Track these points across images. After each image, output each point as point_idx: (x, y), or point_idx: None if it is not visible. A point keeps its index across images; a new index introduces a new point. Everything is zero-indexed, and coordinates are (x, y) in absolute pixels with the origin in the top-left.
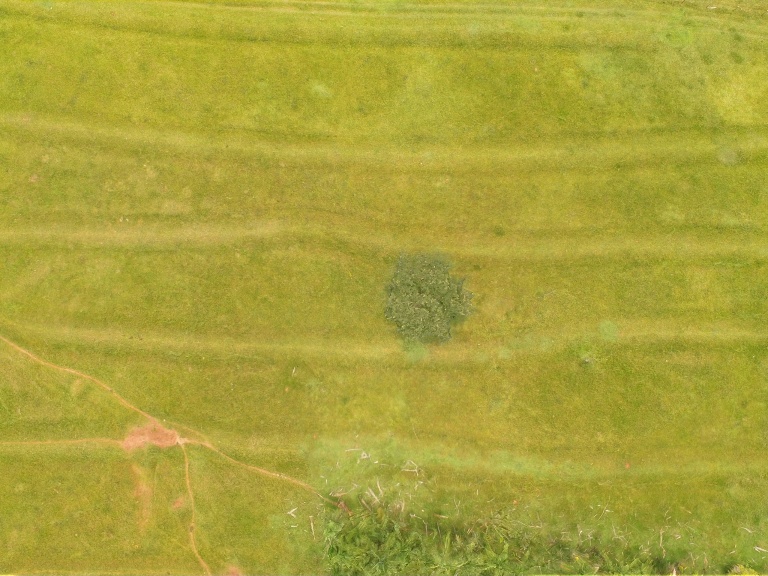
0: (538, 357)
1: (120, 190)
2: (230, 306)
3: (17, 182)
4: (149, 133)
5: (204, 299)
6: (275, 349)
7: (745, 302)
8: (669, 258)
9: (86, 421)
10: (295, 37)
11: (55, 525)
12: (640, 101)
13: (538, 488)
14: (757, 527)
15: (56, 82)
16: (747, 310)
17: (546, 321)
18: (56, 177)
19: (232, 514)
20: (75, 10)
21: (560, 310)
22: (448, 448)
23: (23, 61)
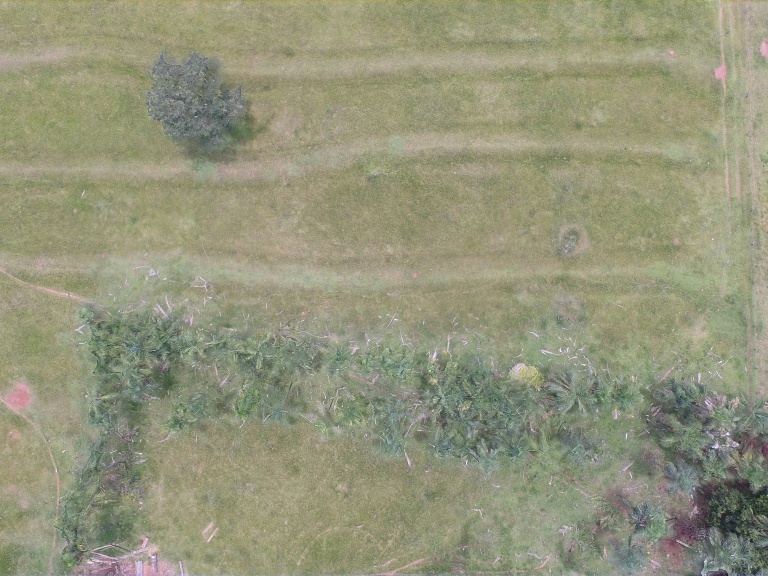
0: (328, 173)
1: None
2: (18, 131)
3: None
4: None
5: None
6: (63, 172)
7: (534, 114)
8: (459, 74)
9: None
10: None
11: None
12: None
13: (327, 300)
14: (544, 331)
15: None
16: (536, 122)
17: (335, 138)
18: None
19: (19, 333)
20: None
21: (349, 127)
22: (237, 264)
23: None
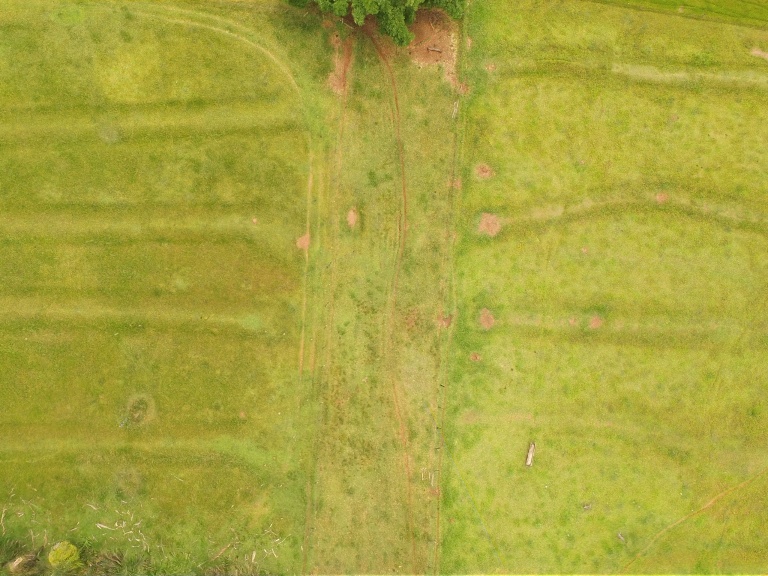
0: None
1: None
2: None
3: None
4: None
5: None
6: None
7: (113, 280)
8: (41, 236)
9: None
10: None
11: None
12: (26, 80)
13: None
14: (102, 504)
15: None
16: (114, 288)
17: None
18: None
19: None
20: None
21: None
22: None
23: None
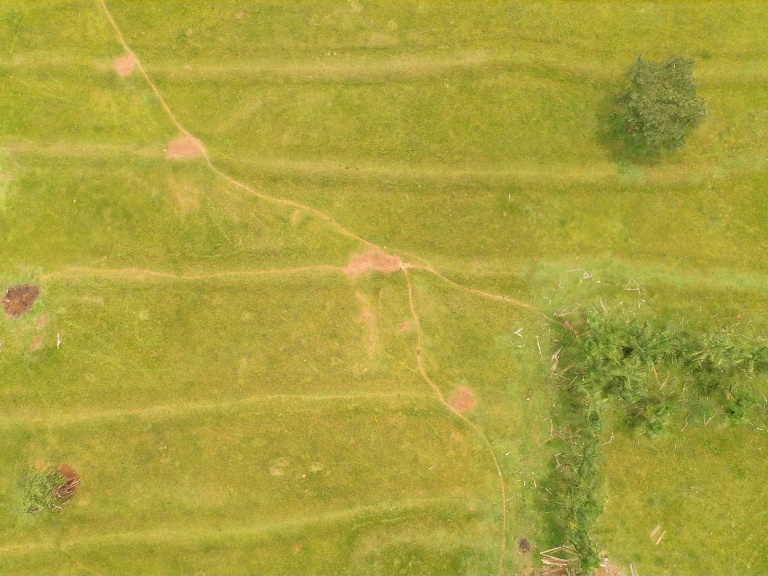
0: (752, 176)
1: (326, 24)
2: (443, 135)
3: (224, 19)
4: None
5: (417, 129)
6: (491, 175)
7: None
8: None
9: (308, 250)
10: None
11: (283, 351)
12: None
13: (760, 303)
14: None
15: None
16: None
17: (759, 140)
18: (262, 13)
19: (459, 336)
20: None
21: None
22: (668, 267)
23: None
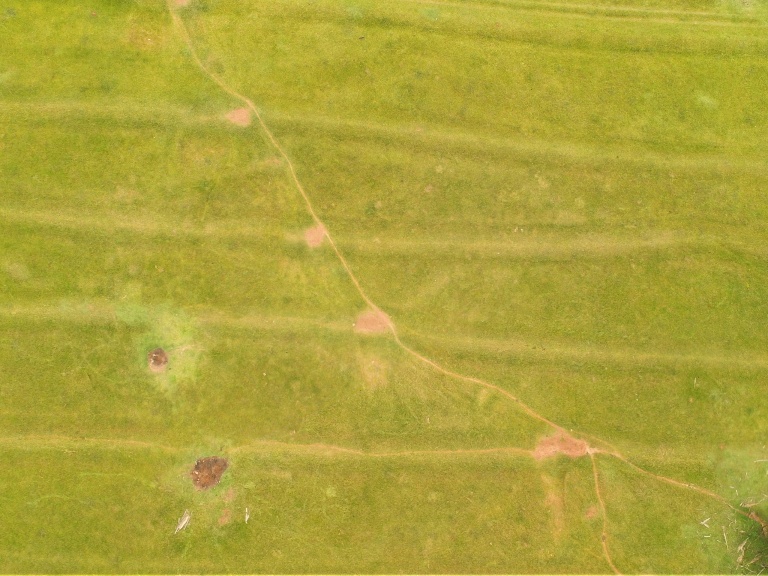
0: None
1: (514, 200)
2: (629, 316)
3: (413, 192)
4: (540, 144)
5: (603, 309)
6: (677, 360)
7: None
8: None
9: (495, 430)
10: (678, 48)
11: (470, 534)
12: None
13: None
14: None
15: (444, 93)
16: None
17: None
18: (450, 187)
19: (645, 524)
20: (460, 21)
21: None
22: None
23: (411, 72)
